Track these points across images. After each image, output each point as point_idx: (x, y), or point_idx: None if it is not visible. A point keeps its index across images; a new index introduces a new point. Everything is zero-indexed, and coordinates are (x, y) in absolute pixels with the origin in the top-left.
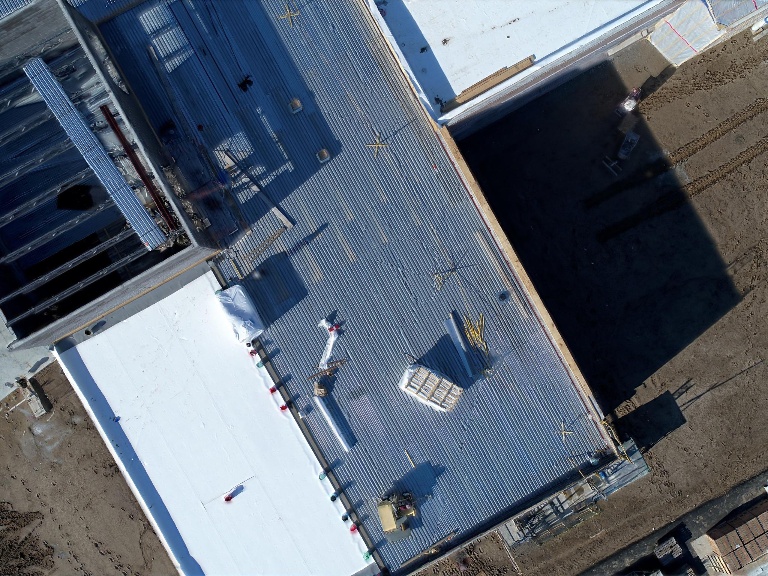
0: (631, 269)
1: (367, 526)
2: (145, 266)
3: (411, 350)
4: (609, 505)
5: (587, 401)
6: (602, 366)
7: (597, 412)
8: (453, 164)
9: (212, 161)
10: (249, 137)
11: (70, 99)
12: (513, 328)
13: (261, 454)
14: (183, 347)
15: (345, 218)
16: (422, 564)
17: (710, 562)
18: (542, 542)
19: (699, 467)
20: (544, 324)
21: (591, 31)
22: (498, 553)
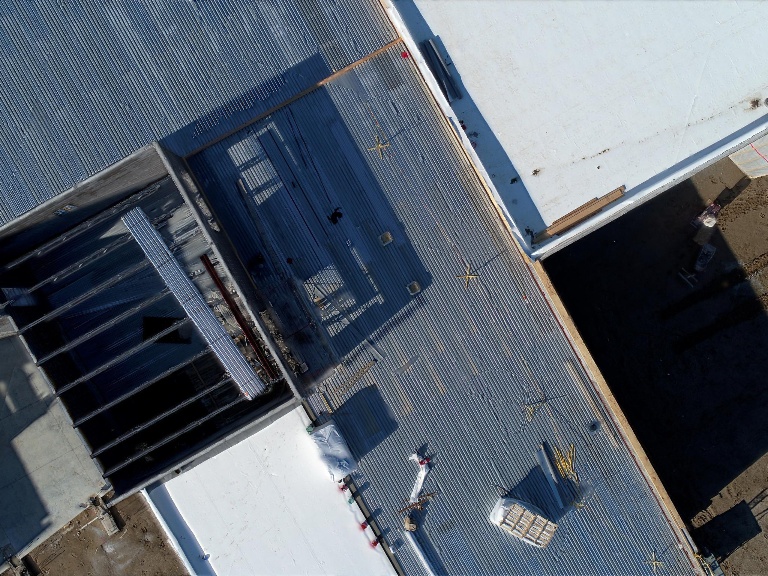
0: (707, 379)
1: None
2: (232, 398)
3: (502, 482)
4: None
5: (680, 534)
6: (678, 477)
7: (690, 545)
8: (543, 295)
9: (301, 294)
10: (339, 269)
11: (169, 248)
12: (604, 458)
13: None
14: (273, 483)
15: (436, 350)
16: None
17: None
18: None
19: None
20: (636, 456)
21: (681, 161)
22: None
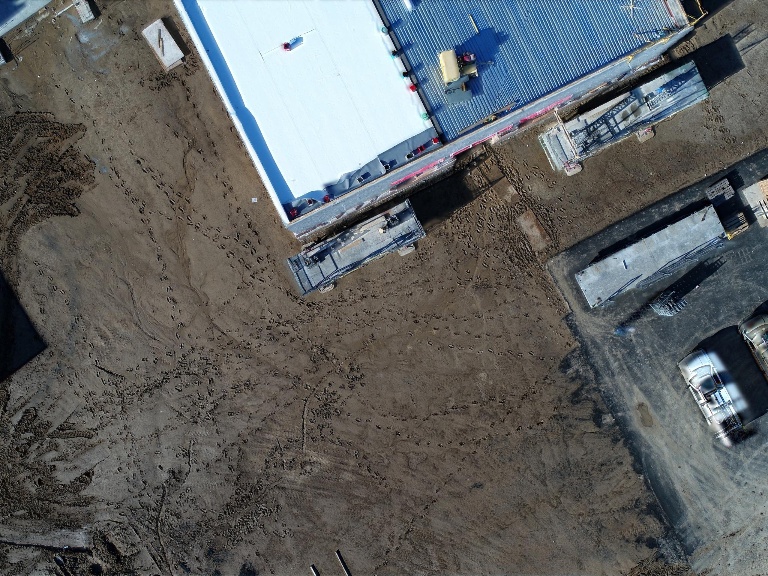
0: None
1: (427, 90)
2: None
3: None
4: (662, 148)
5: None
6: None
7: None
8: None
9: None
10: None
11: None
12: None
13: (323, 7)
14: None
15: None
16: (482, 126)
17: (761, 209)
18: (598, 149)
19: (755, 114)
20: None
21: None
22: (547, 192)
